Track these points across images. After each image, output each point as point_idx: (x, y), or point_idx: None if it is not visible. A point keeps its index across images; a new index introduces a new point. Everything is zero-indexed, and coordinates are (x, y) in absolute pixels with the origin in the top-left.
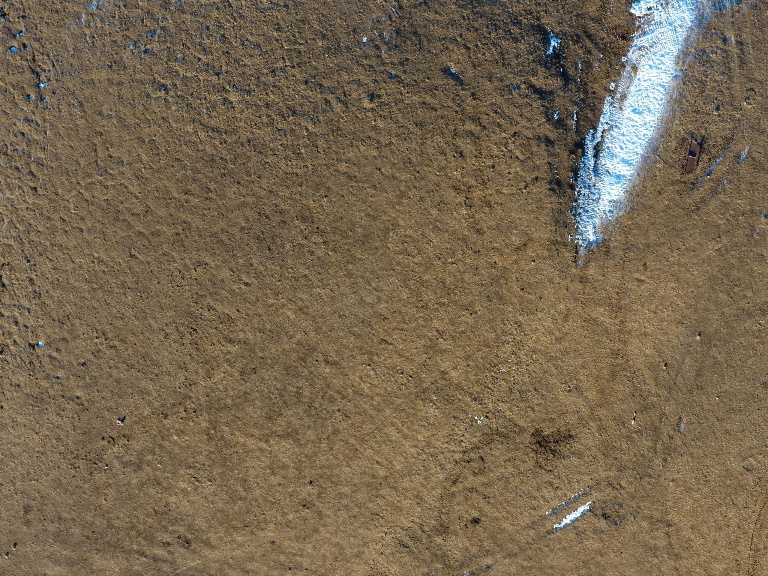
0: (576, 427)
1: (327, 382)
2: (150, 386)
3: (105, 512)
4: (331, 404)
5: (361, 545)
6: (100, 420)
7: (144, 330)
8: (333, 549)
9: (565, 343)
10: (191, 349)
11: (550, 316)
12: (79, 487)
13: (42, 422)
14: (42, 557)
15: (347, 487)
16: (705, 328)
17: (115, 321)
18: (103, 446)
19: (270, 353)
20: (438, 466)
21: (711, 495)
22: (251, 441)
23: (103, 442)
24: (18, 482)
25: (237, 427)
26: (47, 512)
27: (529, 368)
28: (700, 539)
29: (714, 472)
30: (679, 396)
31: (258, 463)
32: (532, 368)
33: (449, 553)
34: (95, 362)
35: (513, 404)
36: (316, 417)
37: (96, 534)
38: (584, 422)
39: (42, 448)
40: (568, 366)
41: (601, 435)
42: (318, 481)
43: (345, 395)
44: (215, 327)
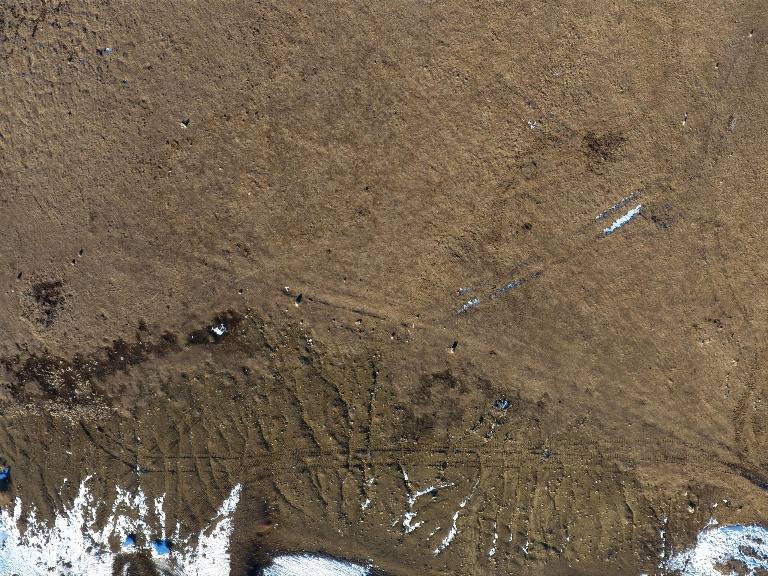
0: (628, 130)
1: (385, 84)
2: (213, 88)
3: (168, 217)
4: (388, 107)
5: (414, 255)
6: (165, 123)
7: (208, 31)
8: (387, 259)
9: (618, 45)
10: (254, 49)
11: (604, 18)
12: (143, 192)
13: (109, 126)
14: (107, 263)
15: (402, 193)
16: (757, 26)
17: (180, 23)
18: (167, 150)
19: (330, 53)
20: (491, 172)
21: (761, 192)
22: (310, 144)
23: (167, 145)
24: (85, 188)
25: (297, 129)
26: (112, 218)
27: (582, 72)
28: (749, 238)
29: (764, 169)
30: (730, 95)
31: (316, 168)
32: (585, 71)
33: (500, 261)
34: (160, 65)
35: (566, 108)
36: (373, 120)
37: (159, 240)
38: (636, 125)
39: (108, 153)
40: (621, 68)
41: (652, 137)
42: (374, 187)
43: (402, 98)
44: (277, 27)
